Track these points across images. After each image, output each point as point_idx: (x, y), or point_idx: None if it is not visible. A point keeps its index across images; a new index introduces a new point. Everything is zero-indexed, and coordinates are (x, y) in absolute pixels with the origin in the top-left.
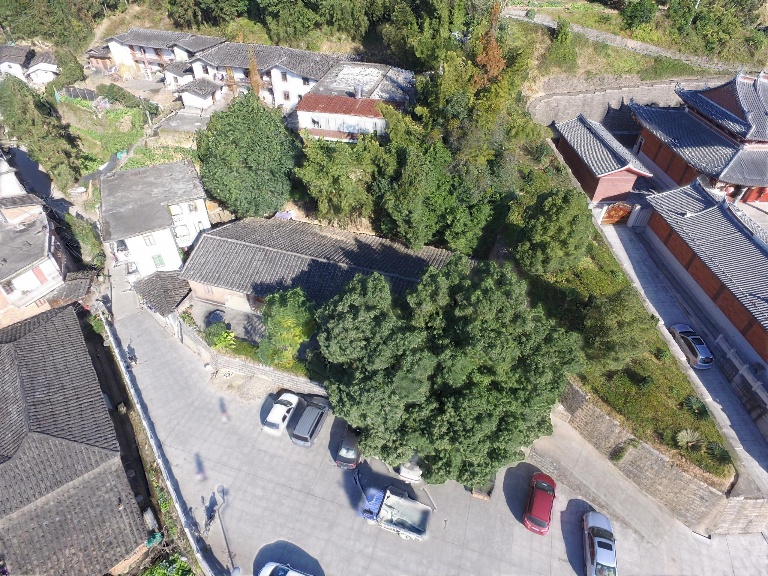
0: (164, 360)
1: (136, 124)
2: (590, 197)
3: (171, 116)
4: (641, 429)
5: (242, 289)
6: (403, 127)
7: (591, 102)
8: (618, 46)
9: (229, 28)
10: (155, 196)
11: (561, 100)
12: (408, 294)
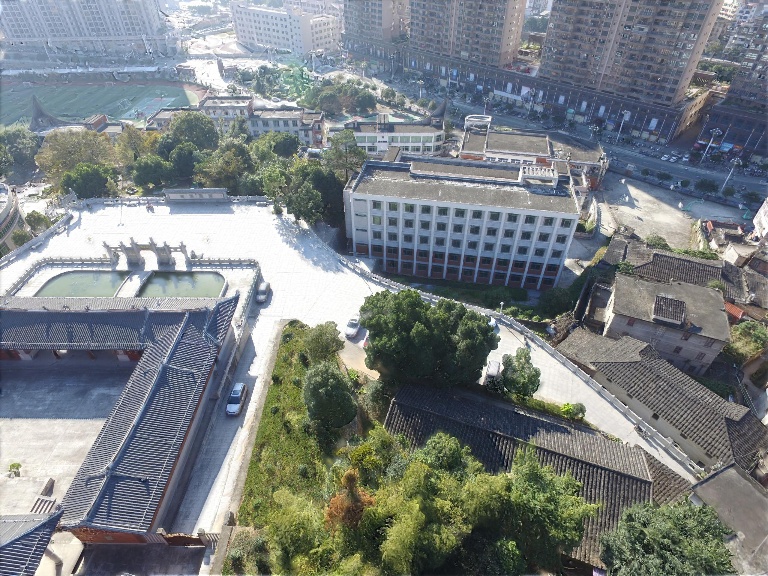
0: (617, 432)
1: None
2: None
3: None
4: None
5: (577, 431)
6: None
7: None
8: None
9: None
10: None
11: None
12: None
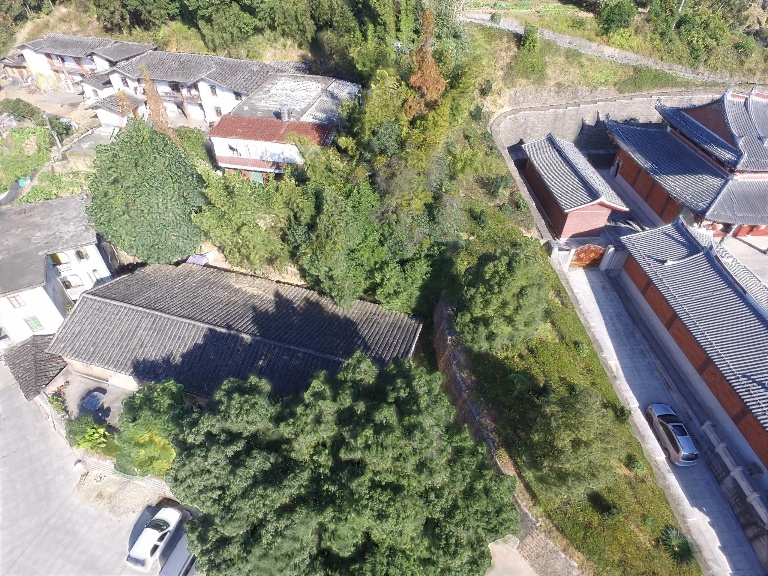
0: (27, 455)
1: (41, 146)
2: (558, 232)
3: (86, 136)
4: (605, 574)
5: (120, 368)
6: (323, 163)
7: (563, 118)
8: (593, 54)
9: (160, 33)
10: (35, 242)
11: (529, 116)
12: (287, 415)
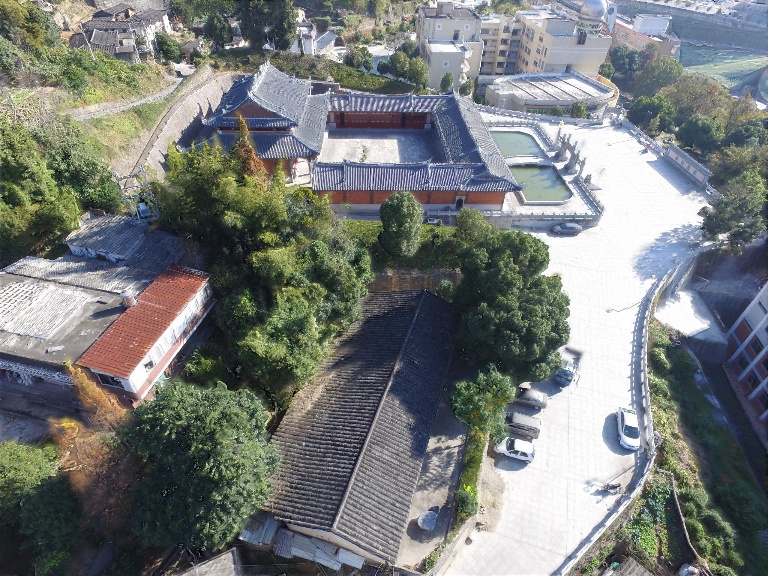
0: None
1: None
2: None
3: None
4: None
5: (417, 472)
6: None
7: None
8: (102, 115)
9: None
10: None
11: None
12: (506, 288)
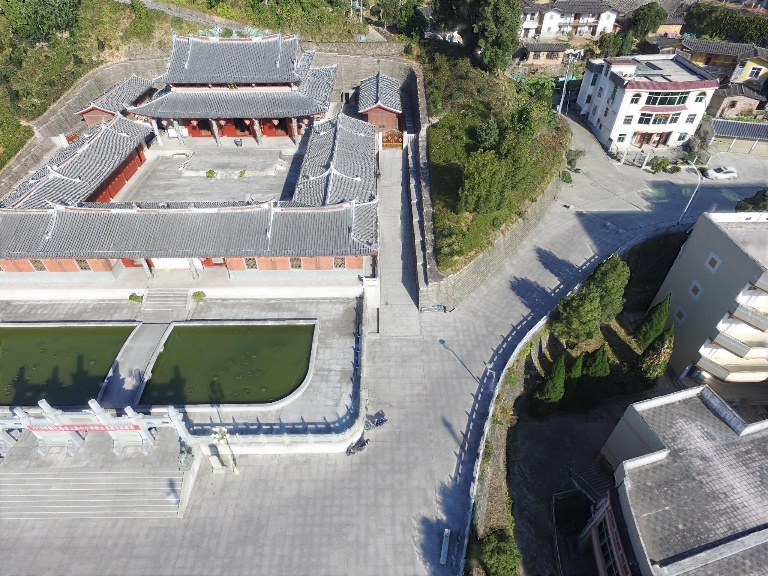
0: None
1: None
2: None
3: None
4: None
5: None
6: None
7: (163, 66)
8: (193, 21)
9: None
10: None
11: (137, 64)
12: None
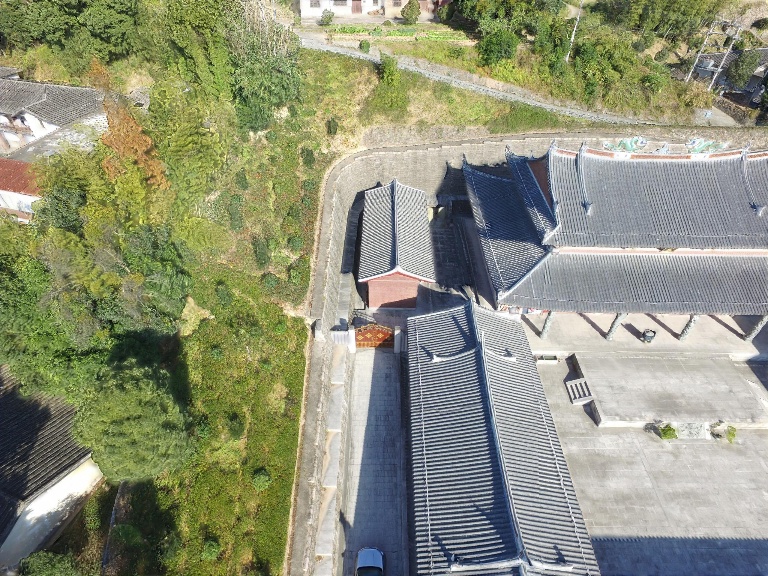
0: None
1: None
2: None
3: None
4: None
5: None
6: (8, 230)
7: (424, 160)
8: (466, 88)
9: (26, 57)
10: None
11: (385, 157)
12: None
